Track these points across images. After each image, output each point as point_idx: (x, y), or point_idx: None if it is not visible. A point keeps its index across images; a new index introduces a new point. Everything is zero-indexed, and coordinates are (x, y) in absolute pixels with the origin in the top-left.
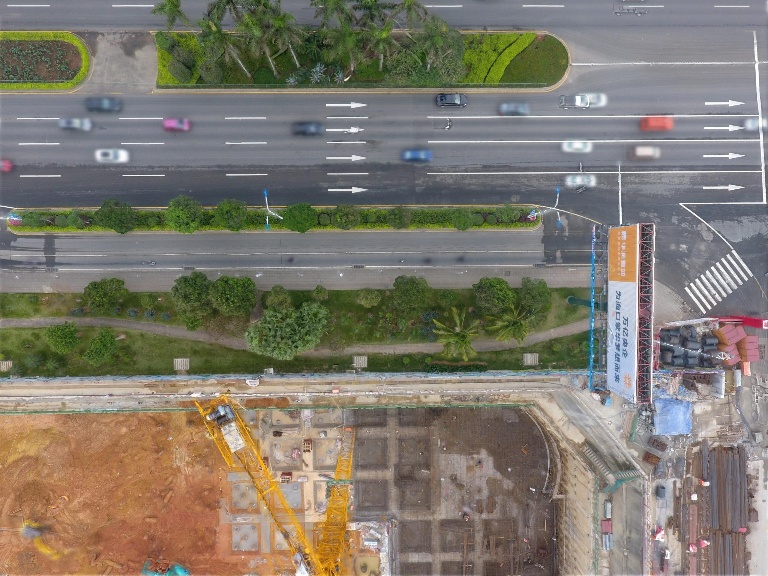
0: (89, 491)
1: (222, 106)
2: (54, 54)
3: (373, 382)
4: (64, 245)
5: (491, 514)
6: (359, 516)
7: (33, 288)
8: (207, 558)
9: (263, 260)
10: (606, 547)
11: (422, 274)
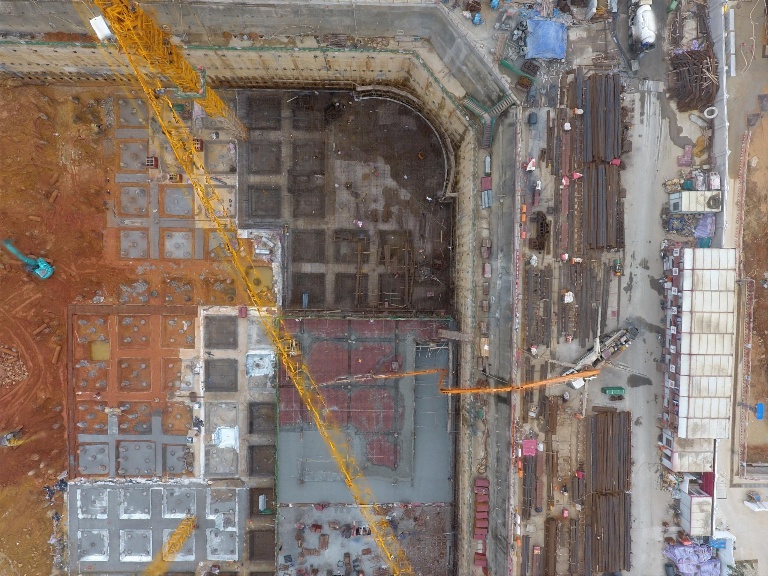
0: None
1: None
2: None
3: None
4: None
5: (387, 225)
6: (251, 222)
7: None
8: (94, 262)
9: None
10: (485, 204)
11: None
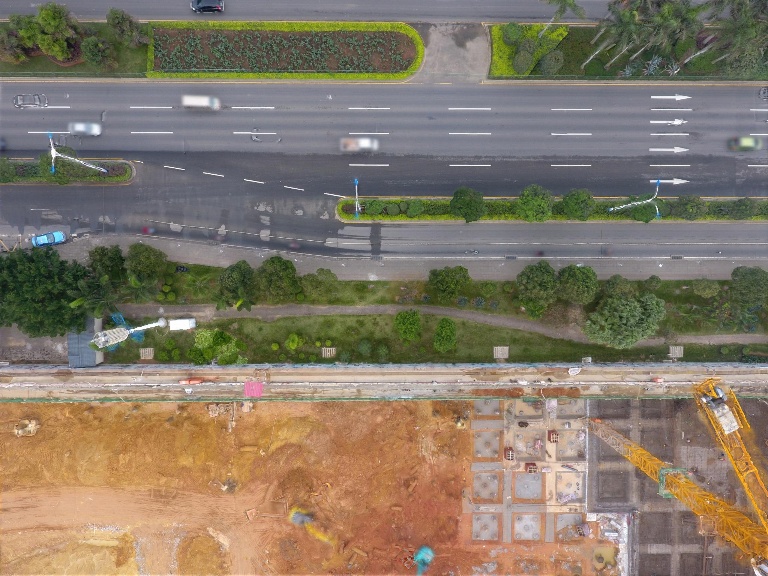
0: (352, 479)
1: (549, 97)
2: (388, 45)
3: (690, 372)
4: (390, 233)
5: None
6: (601, 507)
7: (359, 276)
8: (449, 547)
9: (584, 250)
10: None
11: (739, 265)
